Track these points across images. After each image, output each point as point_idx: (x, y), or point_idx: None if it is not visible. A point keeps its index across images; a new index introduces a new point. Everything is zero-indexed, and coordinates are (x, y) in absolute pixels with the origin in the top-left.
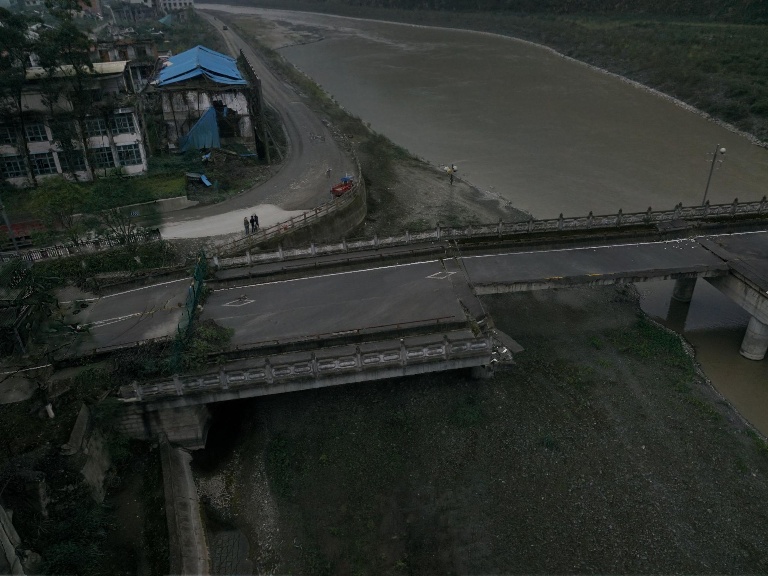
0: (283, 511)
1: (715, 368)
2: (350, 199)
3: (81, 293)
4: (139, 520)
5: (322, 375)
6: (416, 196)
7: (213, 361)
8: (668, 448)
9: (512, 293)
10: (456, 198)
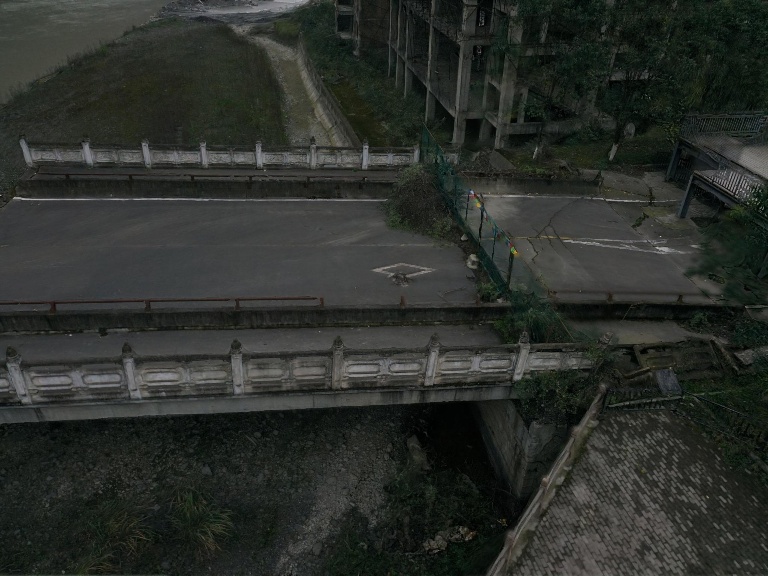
0: None
1: None
2: None
3: None
4: None
5: None
6: None
7: None
8: None
9: None
10: None
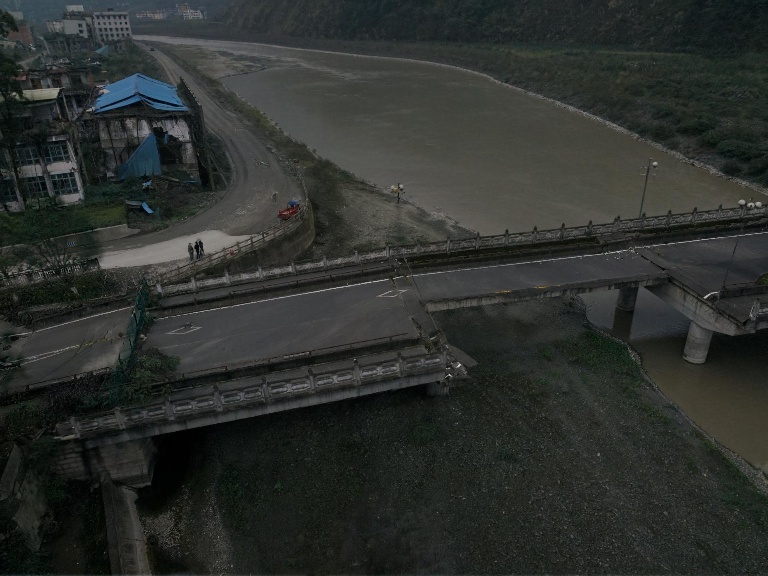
0: (237, 546)
1: (661, 373)
2: (297, 222)
3: (12, 328)
4: (79, 567)
5: (274, 400)
6: (364, 218)
7: (158, 391)
8: (622, 454)
9: (463, 310)
10: (404, 219)
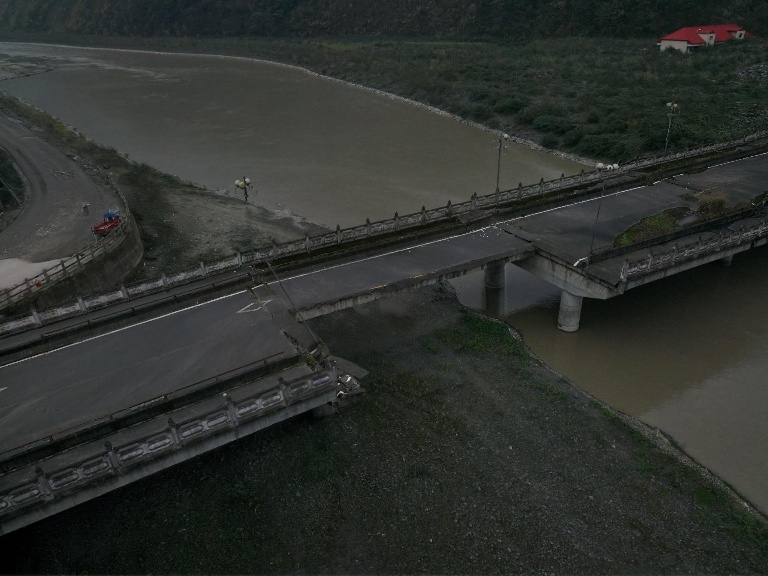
0: None
1: (542, 347)
2: (120, 237)
3: None
4: None
5: (126, 468)
6: (199, 225)
7: None
8: (533, 441)
9: None
10: (245, 221)
